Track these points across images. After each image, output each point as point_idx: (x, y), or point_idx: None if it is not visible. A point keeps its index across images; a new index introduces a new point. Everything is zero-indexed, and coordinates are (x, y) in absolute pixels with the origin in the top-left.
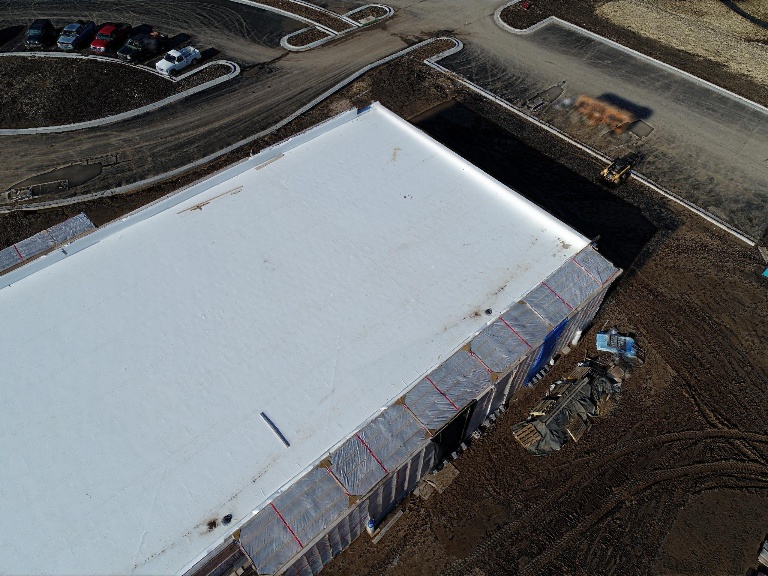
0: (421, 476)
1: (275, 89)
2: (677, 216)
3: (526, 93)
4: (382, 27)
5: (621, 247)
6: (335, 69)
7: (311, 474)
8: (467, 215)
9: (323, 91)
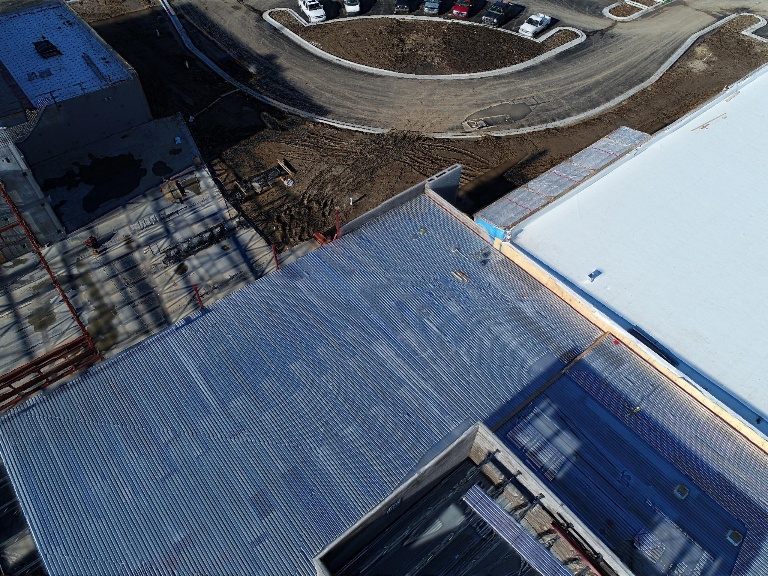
0: None
1: (628, 51)
2: None
3: None
4: (683, 4)
5: None
6: (668, 36)
7: None
8: None
9: (670, 53)
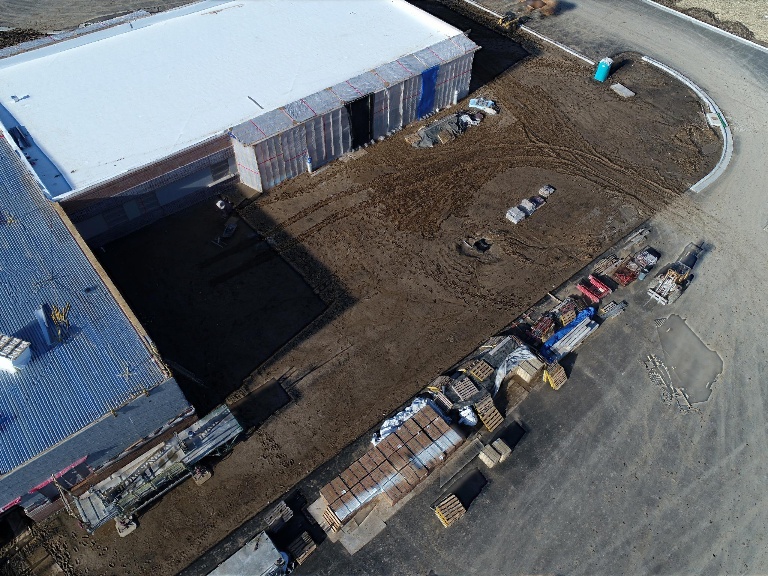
0: (344, 151)
1: None
2: (546, 49)
3: None
4: None
5: (501, 62)
6: None
7: (273, 111)
8: (389, 23)
9: None
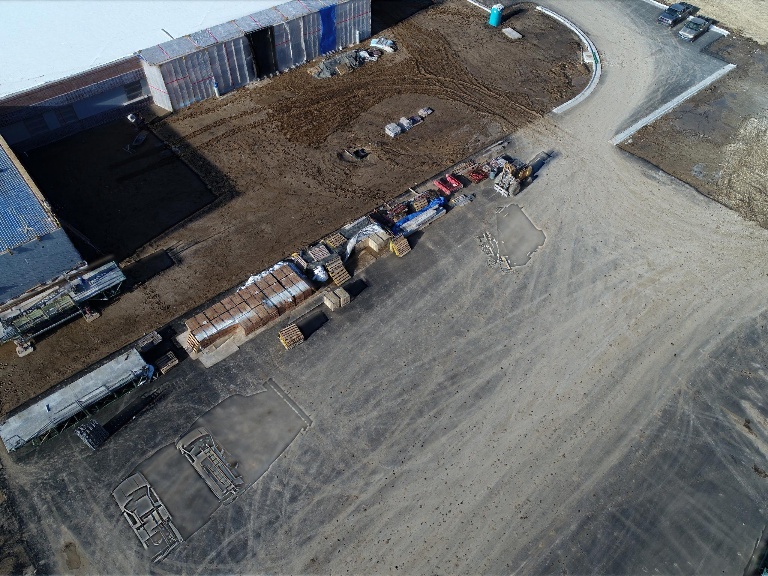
0: (250, 80)
1: None
2: None
3: None
4: None
5: (407, 10)
6: None
7: (180, 38)
8: None
9: None
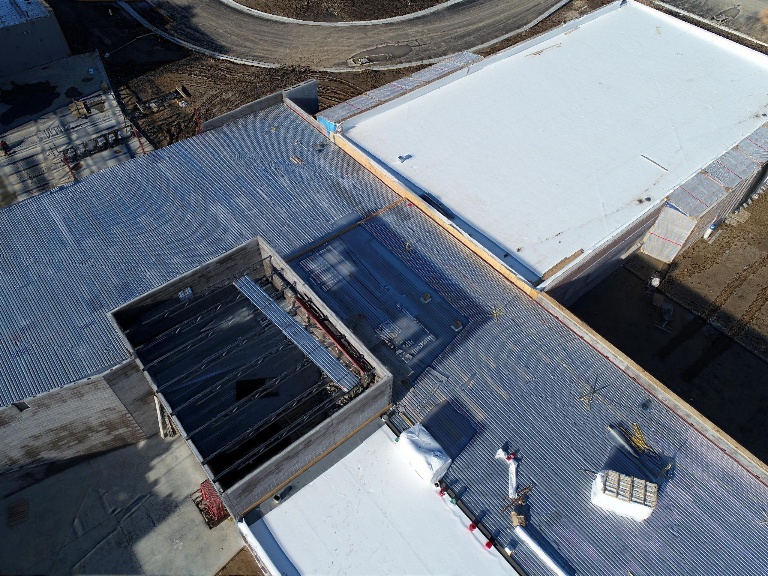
0: (728, 213)
1: (513, 3)
2: None
3: (711, 11)
4: None
5: None
6: None
7: (697, 176)
8: (726, 65)
9: (551, 6)
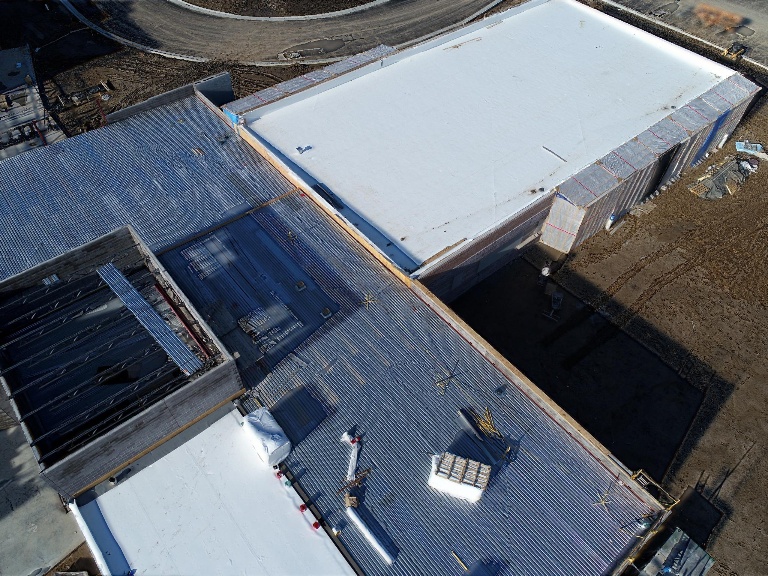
0: (633, 204)
1: None
2: None
3: (650, 6)
4: None
5: None
6: None
7: (591, 167)
8: (644, 58)
9: (491, 1)
